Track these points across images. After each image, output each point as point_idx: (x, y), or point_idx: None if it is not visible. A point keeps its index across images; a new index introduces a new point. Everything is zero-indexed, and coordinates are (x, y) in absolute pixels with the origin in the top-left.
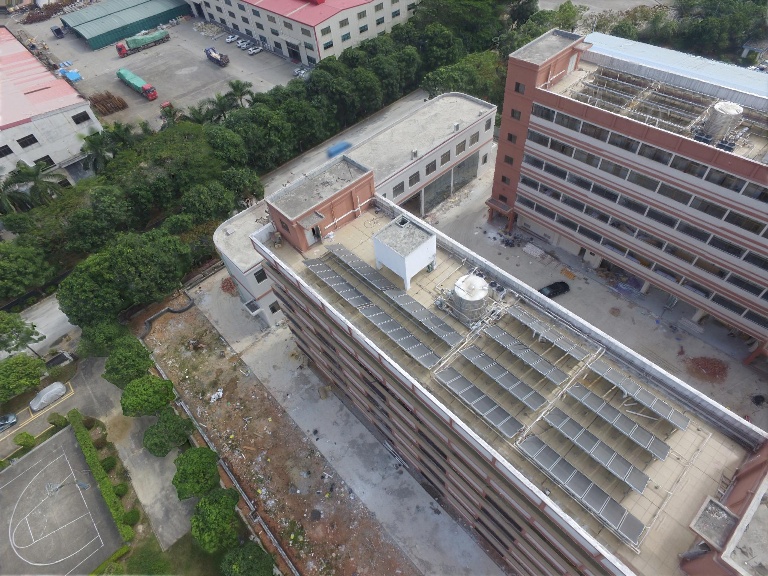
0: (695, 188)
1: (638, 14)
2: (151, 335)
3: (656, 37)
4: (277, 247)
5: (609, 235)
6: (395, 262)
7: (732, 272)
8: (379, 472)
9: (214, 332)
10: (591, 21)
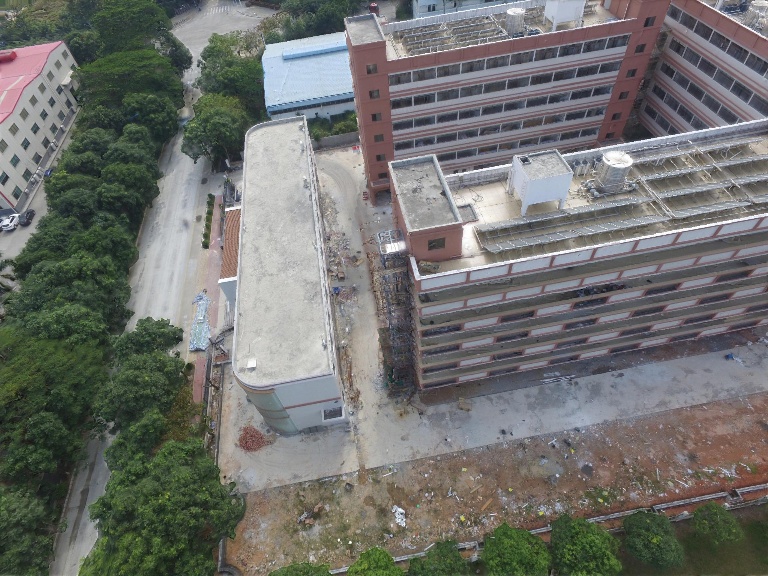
0: (531, 70)
1: (266, 25)
2: (248, 571)
3: (295, 36)
4: (438, 271)
5: (482, 143)
6: (556, 188)
7: (567, 112)
8: (569, 399)
9: (307, 485)
10: (242, 43)
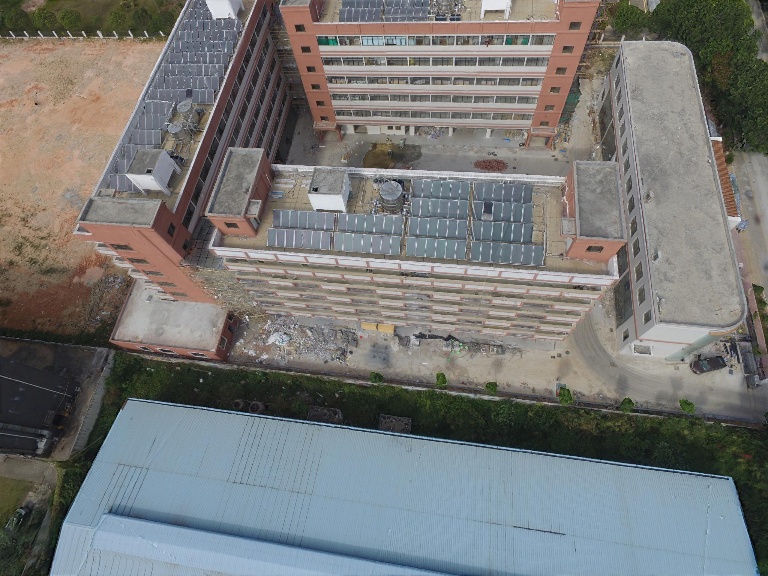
0: None
1: None
2: None
3: None
4: None
5: None
6: None
7: None
8: None
9: None
10: None
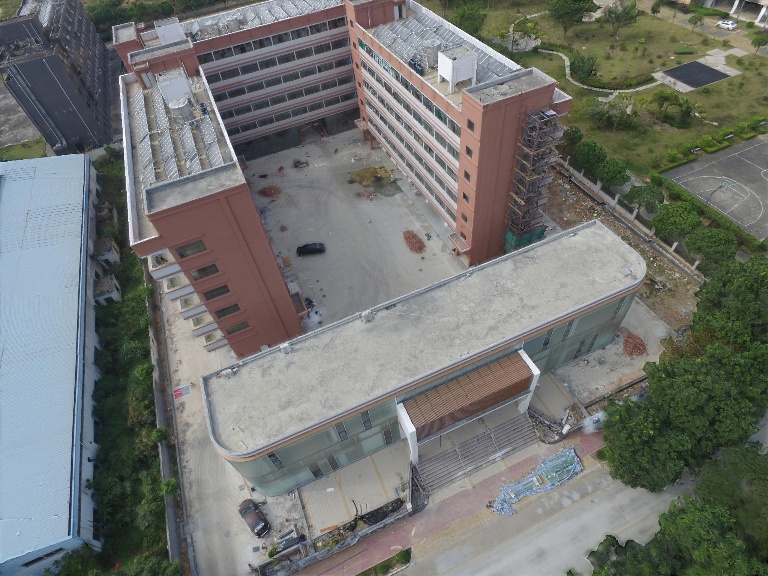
0: None
1: None
2: None
3: None
4: None
5: None
6: None
7: None
8: None
9: None
10: None
